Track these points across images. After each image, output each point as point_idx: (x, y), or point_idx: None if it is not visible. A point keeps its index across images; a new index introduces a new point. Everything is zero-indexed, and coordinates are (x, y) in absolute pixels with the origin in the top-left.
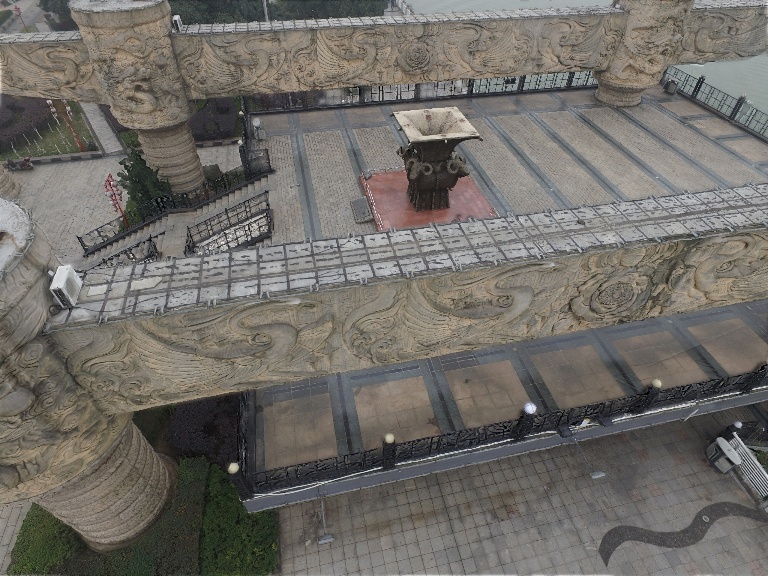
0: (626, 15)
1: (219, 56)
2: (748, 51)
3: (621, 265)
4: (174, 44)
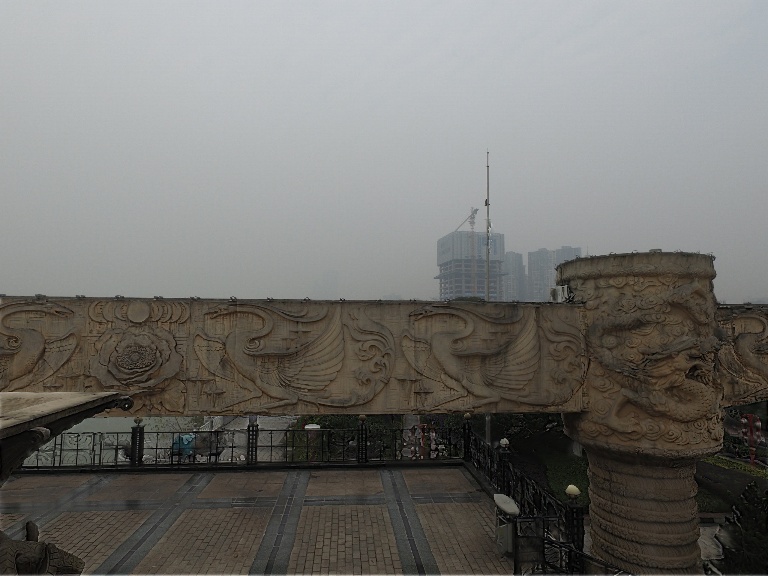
0: None
1: None
2: None
3: None
4: None
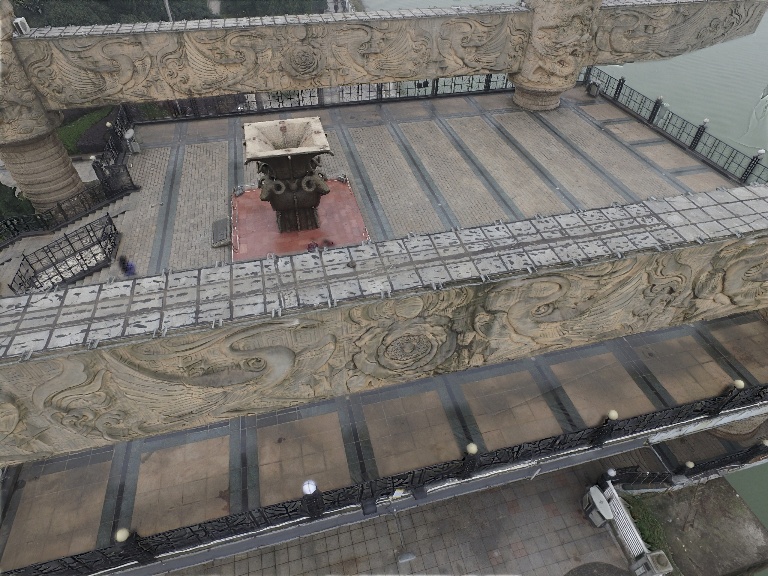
0: (531, 14)
1: (73, 62)
2: (669, 51)
3: (400, 316)
4: (17, 49)
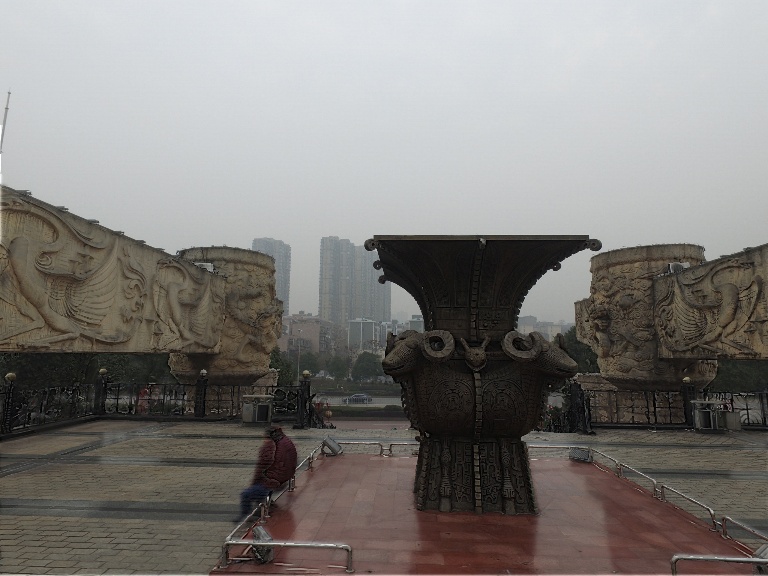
0: None
1: (685, 298)
2: None
3: None
4: (656, 289)
